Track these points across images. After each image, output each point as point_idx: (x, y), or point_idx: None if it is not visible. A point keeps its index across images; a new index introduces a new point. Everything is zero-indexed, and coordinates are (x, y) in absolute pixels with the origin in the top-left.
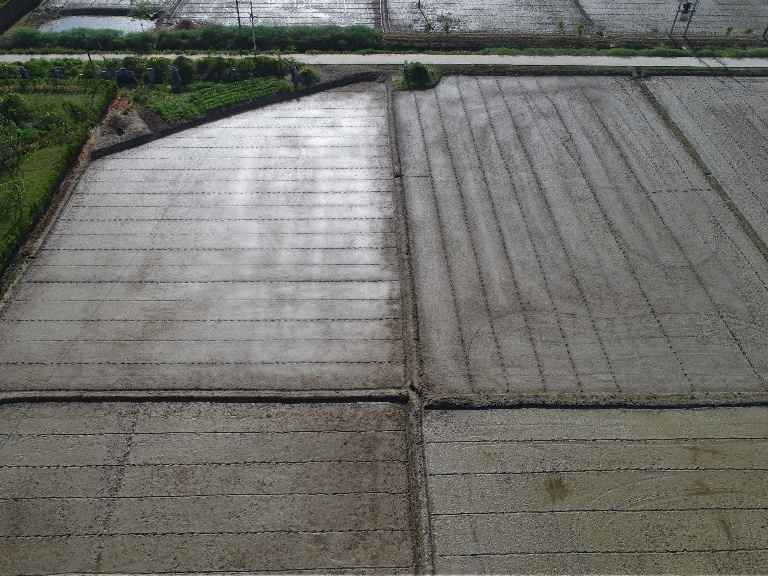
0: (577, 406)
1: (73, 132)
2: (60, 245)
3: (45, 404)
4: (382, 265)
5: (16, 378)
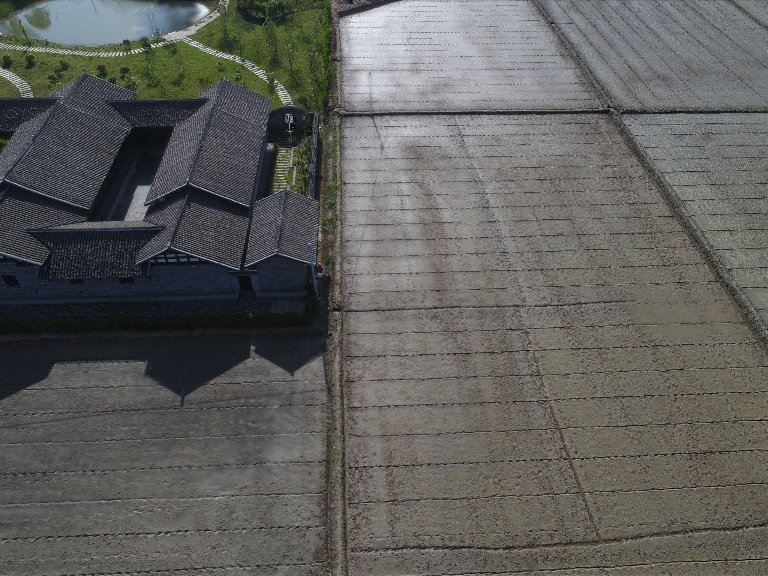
0: (708, 112)
1: (319, 2)
2: (352, 55)
3: (399, 116)
4: (564, 62)
5: (373, 107)
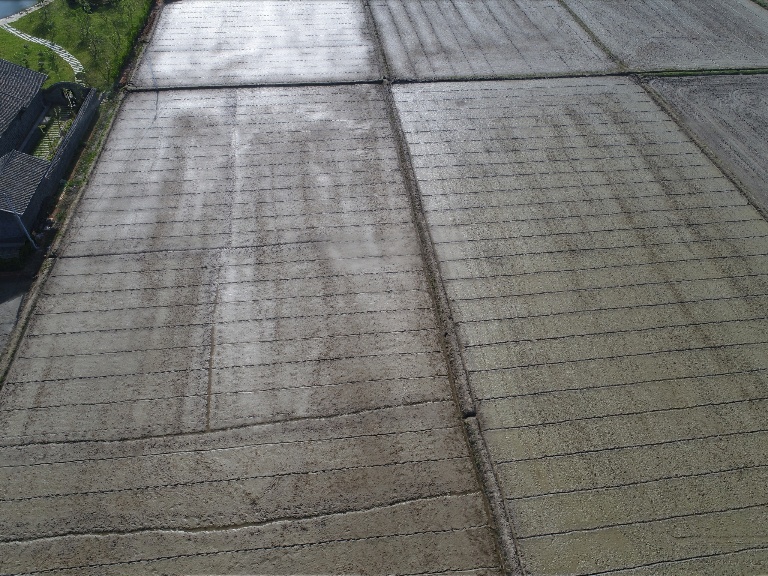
0: (473, 80)
1: None
2: (162, 38)
3: (183, 90)
4: (362, 40)
5: (162, 83)
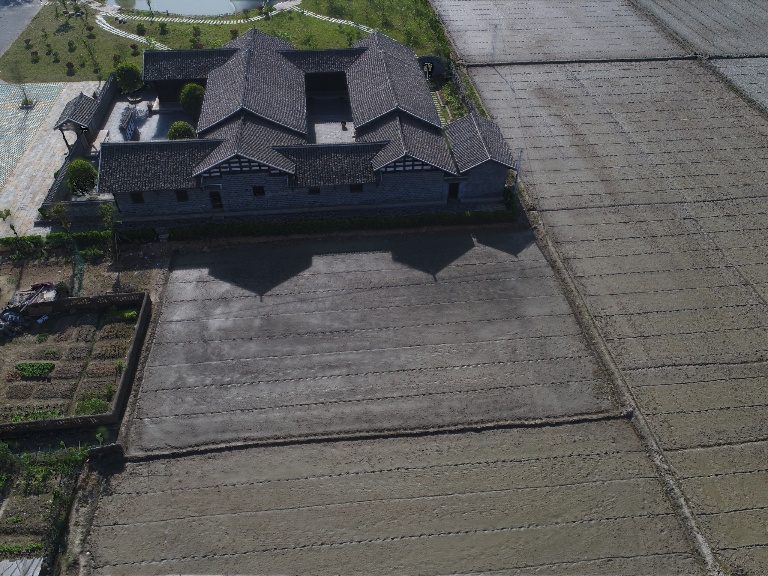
0: None
1: None
2: (452, 19)
3: (516, 65)
4: (641, 21)
5: (490, 59)
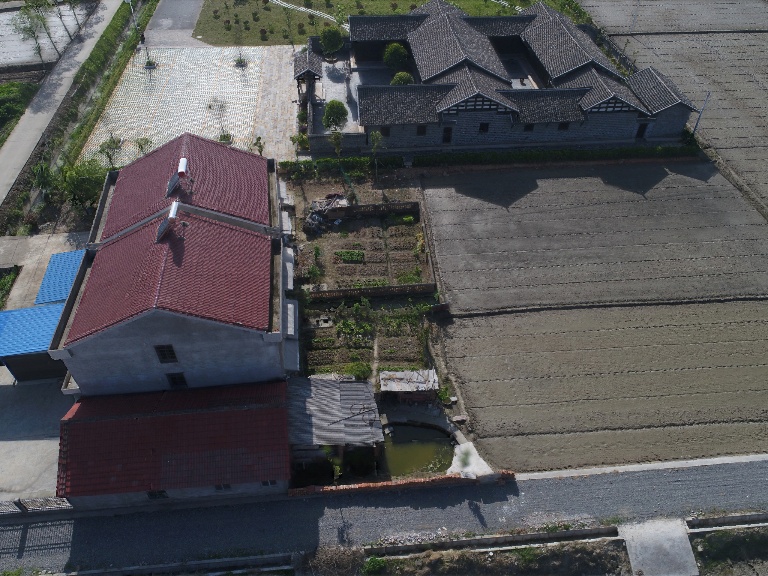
0: None
1: None
2: None
3: (652, 35)
4: None
5: None
